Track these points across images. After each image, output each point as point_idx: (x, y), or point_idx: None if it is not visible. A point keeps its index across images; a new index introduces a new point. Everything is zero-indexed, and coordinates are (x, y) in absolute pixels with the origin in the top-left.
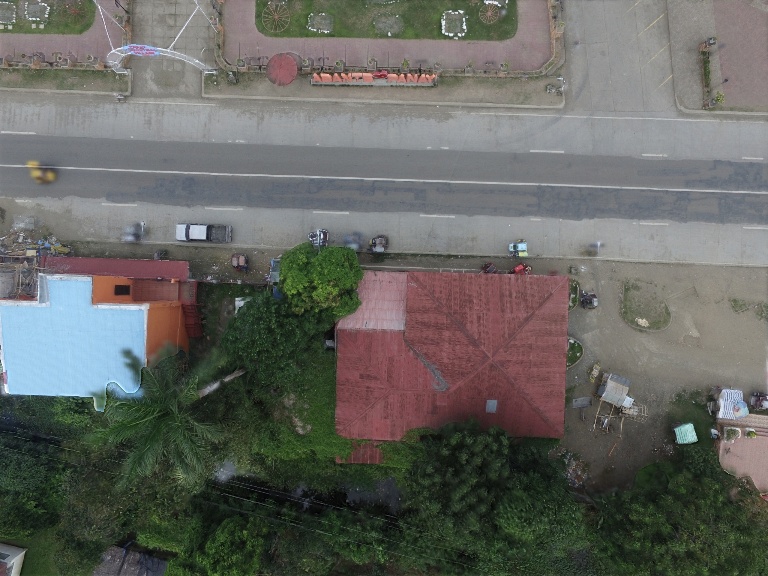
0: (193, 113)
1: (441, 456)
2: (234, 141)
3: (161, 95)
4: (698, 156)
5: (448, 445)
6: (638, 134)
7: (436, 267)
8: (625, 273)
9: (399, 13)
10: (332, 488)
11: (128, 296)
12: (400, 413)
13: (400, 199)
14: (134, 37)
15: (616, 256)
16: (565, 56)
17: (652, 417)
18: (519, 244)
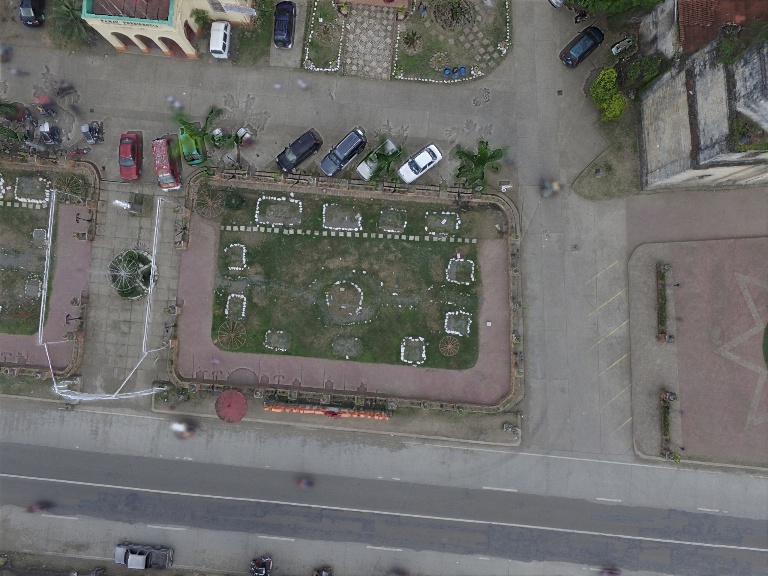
0: (142, 426)
1: None
2: (182, 458)
3: (110, 404)
4: (653, 504)
5: None
6: (594, 477)
7: None
8: None
9: (359, 335)
10: None
11: None
12: None
13: (348, 529)
14: (86, 342)
15: None
16: (524, 391)
17: None
18: None
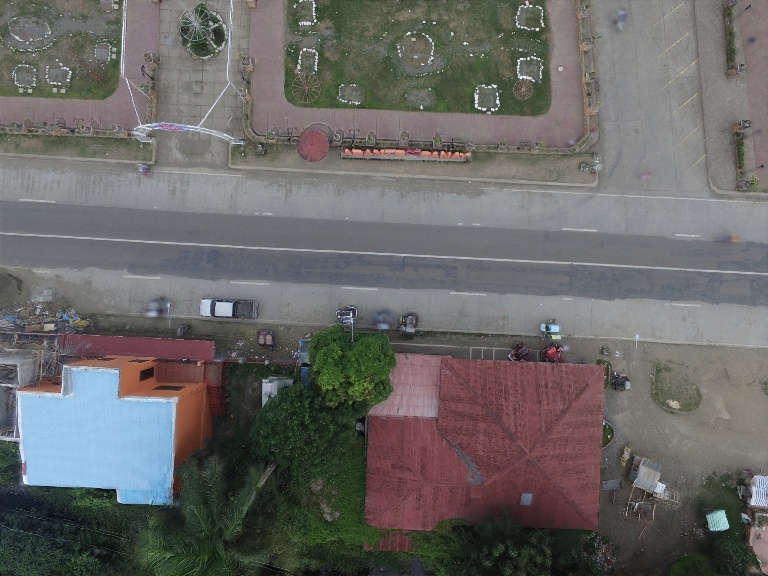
0: (219, 184)
1: (481, 565)
2: (261, 213)
3: (186, 164)
4: (731, 237)
5: (490, 556)
6: (671, 214)
7: (466, 345)
8: (657, 354)
9: (431, 86)
10: (356, 568)
11: (152, 378)
12: (432, 505)
13: (430, 276)
14: (159, 104)
15: (648, 337)
16: (599, 133)
17: (682, 500)
18: (552, 326)
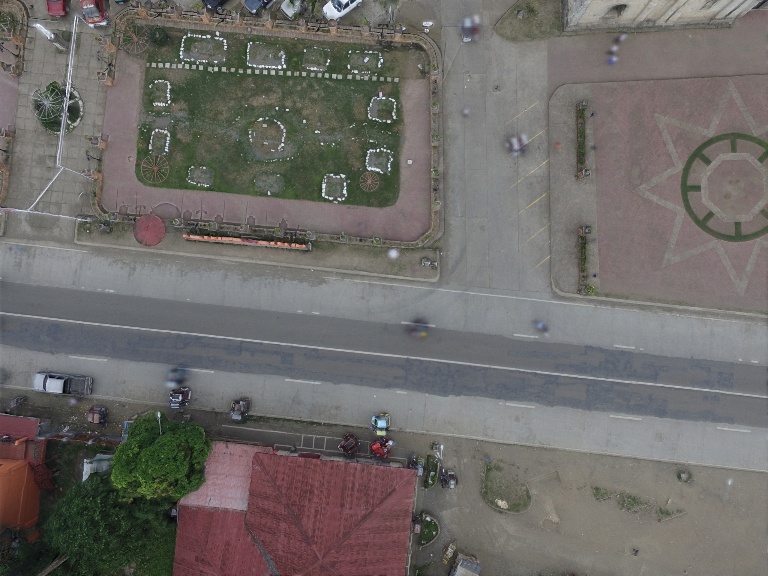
0: (65, 258)
1: None
2: (104, 290)
3: (34, 237)
4: (570, 340)
5: None
6: (511, 313)
7: (298, 433)
8: (488, 453)
9: (281, 172)
10: None
11: None
12: None
13: (267, 361)
14: (12, 176)
15: (480, 435)
16: (444, 228)
17: None
18: (379, 421)
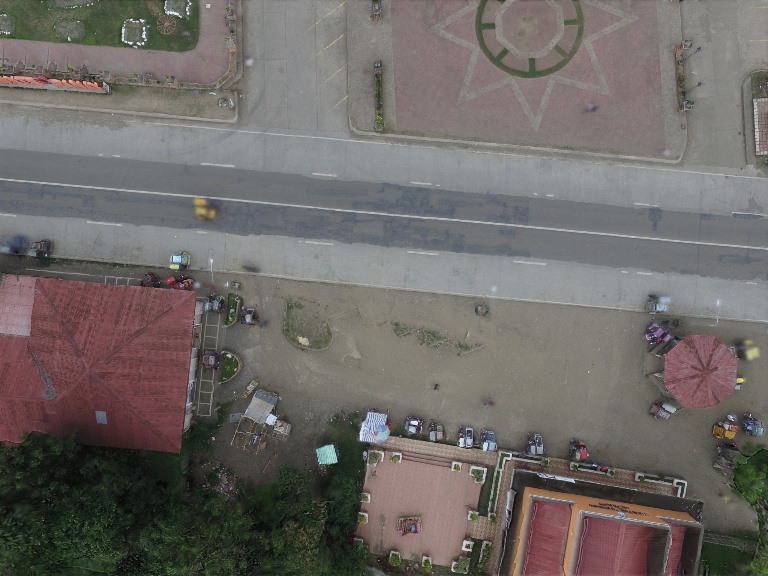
0: None
1: None
2: None
3: None
4: (367, 178)
5: None
6: (309, 153)
7: (101, 274)
8: (289, 291)
9: (81, 18)
10: None
11: None
12: (13, 419)
13: (68, 204)
14: None
15: (280, 273)
16: (243, 71)
17: (308, 436)
18: (174, 256)
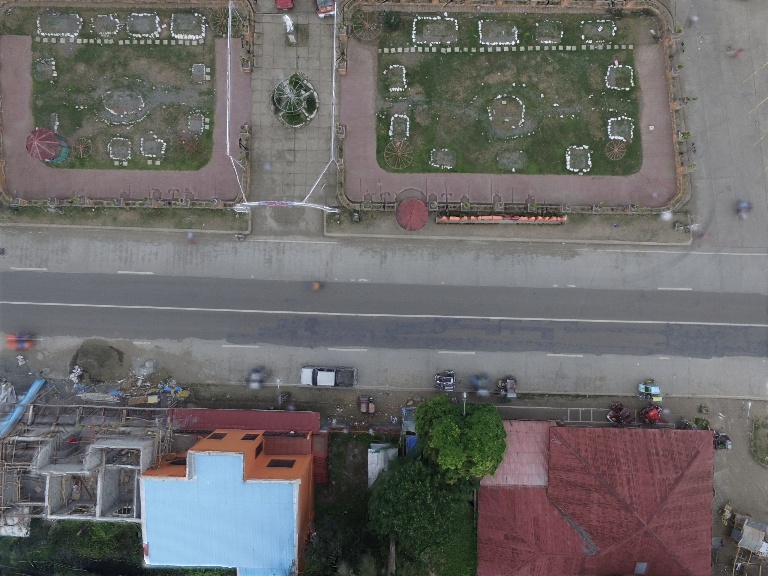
0: (315, 251)
1: None
2: (357, 280)
3: (281, 233)
4: None
5: None
6: (766, 270)
7: (564, 407)
8: (755, 411)
9: (523, 148)
10: None
11: (261, 452)
12: (546, 574)
13: (527, 338)
14: (253, 173)
15: (746, 395)
16: (691, 191)
17: None
18: (652, 388)
